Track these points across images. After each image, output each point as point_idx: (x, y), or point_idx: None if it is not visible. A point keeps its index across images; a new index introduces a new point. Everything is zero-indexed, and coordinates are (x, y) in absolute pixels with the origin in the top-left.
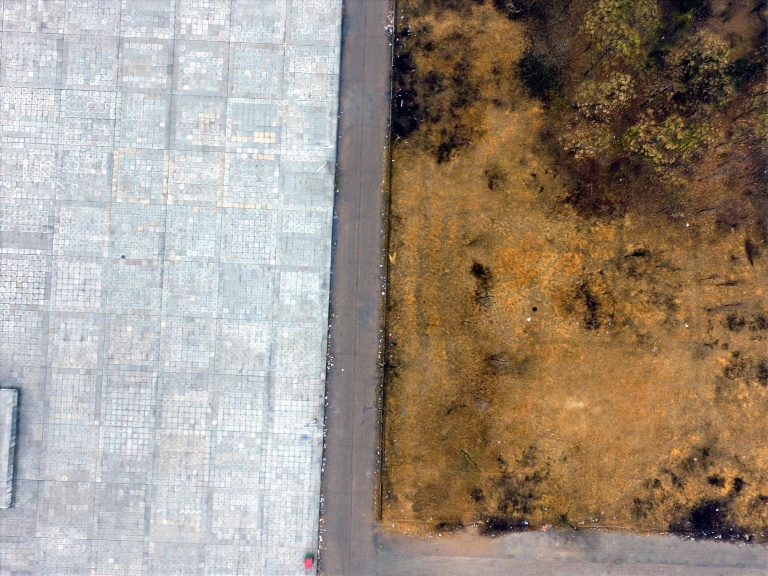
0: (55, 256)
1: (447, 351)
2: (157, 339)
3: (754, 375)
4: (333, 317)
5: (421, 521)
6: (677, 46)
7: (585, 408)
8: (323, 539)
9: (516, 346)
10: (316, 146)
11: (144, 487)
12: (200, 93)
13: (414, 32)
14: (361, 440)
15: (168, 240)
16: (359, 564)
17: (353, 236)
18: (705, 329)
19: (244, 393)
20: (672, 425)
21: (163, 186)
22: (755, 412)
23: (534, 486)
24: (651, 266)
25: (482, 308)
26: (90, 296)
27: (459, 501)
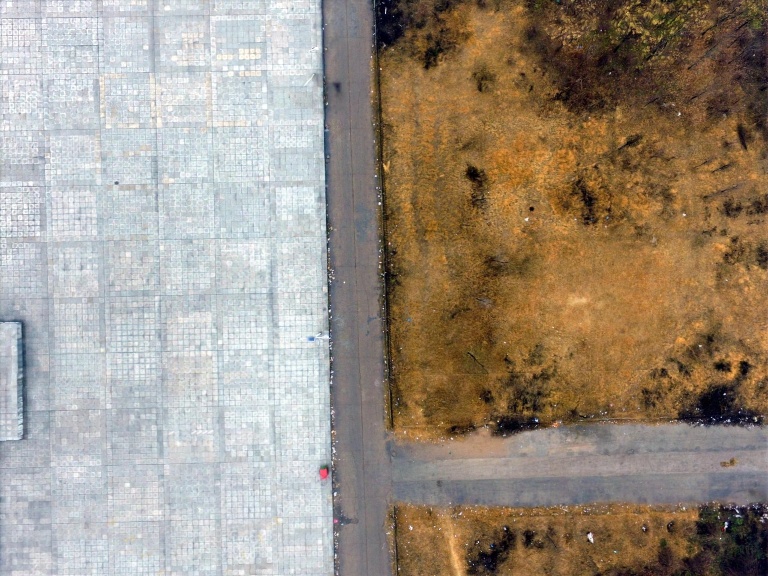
0: (48, 187)
1: (447, 256)
2: (157, 263)
3: (754, 259)
4: (331, 230)
5: (432, 426)
6: None
7: (588, 303)
8: (336, 450)
9: (515, 246)
10: (302, 59)
11: (155, 411)
12: (182, 13)
13: None
14: (367, 350)
15: (160, 163)
16: (373, 472)
17: (346, 148)
18: (703, 216)
19: (247, 311)
20: (675, 314)
21: (151, 109)
22: (757, 295)
23: (542, 384)
24: (645, 157)
25: (479, 211)
26: (86, 224)
27: (468, 403)
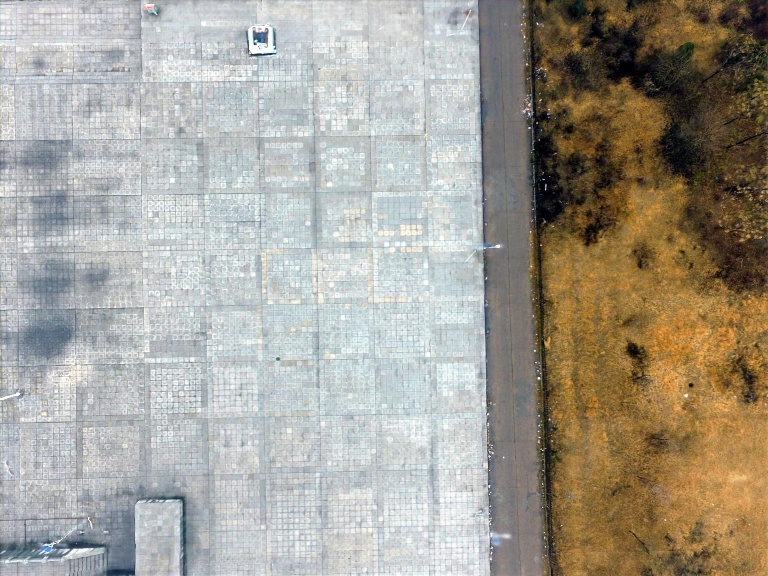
0: (209, 363)
1: (607, 433)
2: (317, 439)
3: None
4: (490, 405)
5: None
6: None
7: (748, 481)
8: None
9: (676, 423)
10: (463, 235)
11: None
12: (344, 189)
13: (554, 115)
14: (527, 526)
15: (322, 339)
16: None
17: (505, 323)
18: None
19: (408, 488)
20: None
21: (313, 285)
22: None
23: (702, 561)
24: None
25: (639, 388)
26: (247, 401)
27: None
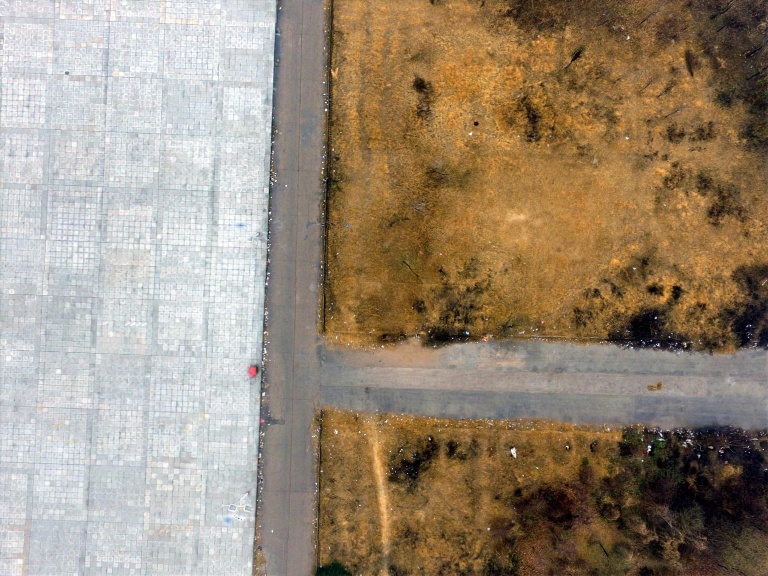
0: None
1: (389, 165)
2: (101, 154)
3: (693, 185)
4: (276, 133)
5: (364, 332)
6: None
7: (526, 220)
8: (267, 351)
9: (457, 159)
10: None
11: (90, 300)
12: None
13: None
14: (305, 254)
15: (111, 56)
16: (303, 375)
17: (296, 53)
18: (645, 140)
19: (188, 207)
20: (612, 235)
21: (106, 2)
22: (694, 221)
23: (475, 297)
24: (592, 78)
25: (424, 122)
26: (35, 112)
27: (401, 312)
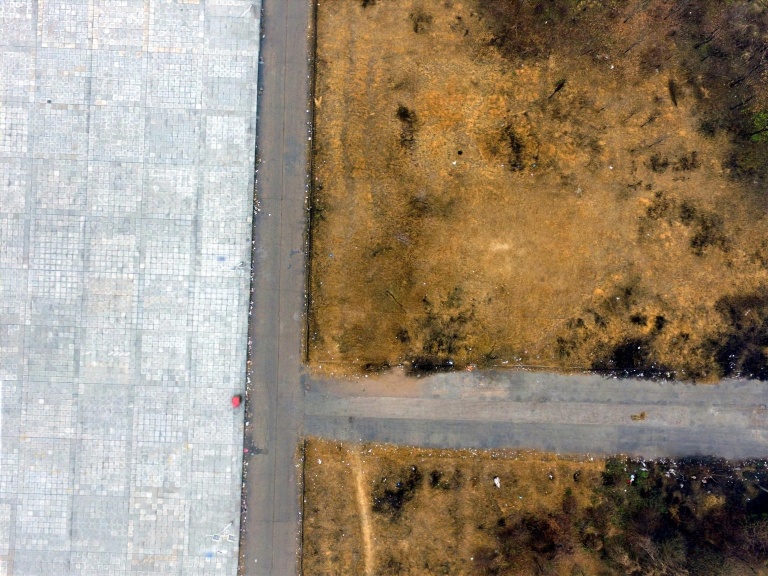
0: None
1: (373, 194)
2: (84, 183)
3: (677, 215)
4: (260, 162)
5: (347, 362)
6: None
7: (510, 250)
8: (251, 381)
9: (441, 189)
10: None
11: (73, 329)
12: None
13: None
14: (288, 284)
15: (94, 85)
16: (287, 405)
17: (279, 81)
18: (629, 170)
19: (171, 237)
20: (595, 265)
21: (88, 31)
22: (677, 251)
23: (459, 327)
24: (576, 108)
25: (407, 151)
26: (17, 141)
27: (385, 342)
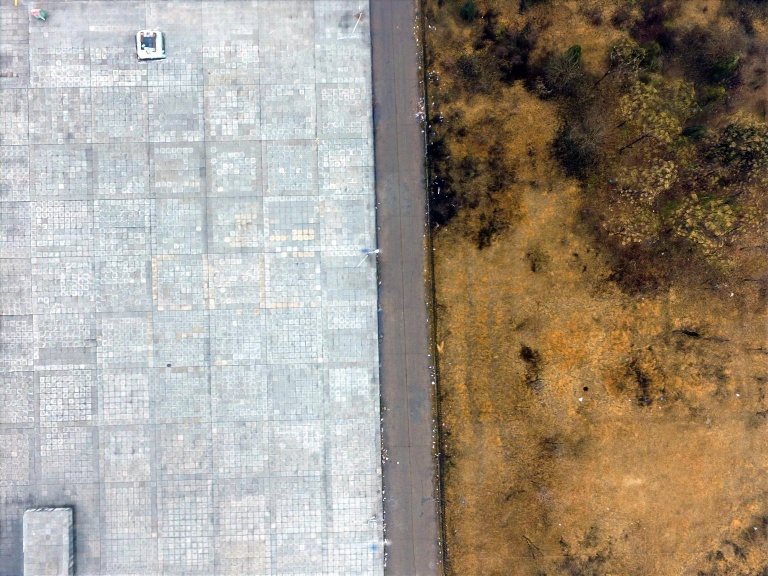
0: (100, 370)
1: (501, 437)
2: (209, 446)
3: None
4: (384, 410)
5: None
6: (710, 116)
7: (643, 484)
8: None
9: (570, 427)
10: (356, 240)
11: None
12: (235, 194)
13: (446, 118)
14: (421, 532)
15: (213, 345)
16: None
17: (399, 327)
18: (756, 398)
19: (301, 494)
20: (730, 496)
21: (204, 291)
22: None
23: (597, 566)
24: (699, 338)
25: (533, 392)
26: (138, 408)
27: None
